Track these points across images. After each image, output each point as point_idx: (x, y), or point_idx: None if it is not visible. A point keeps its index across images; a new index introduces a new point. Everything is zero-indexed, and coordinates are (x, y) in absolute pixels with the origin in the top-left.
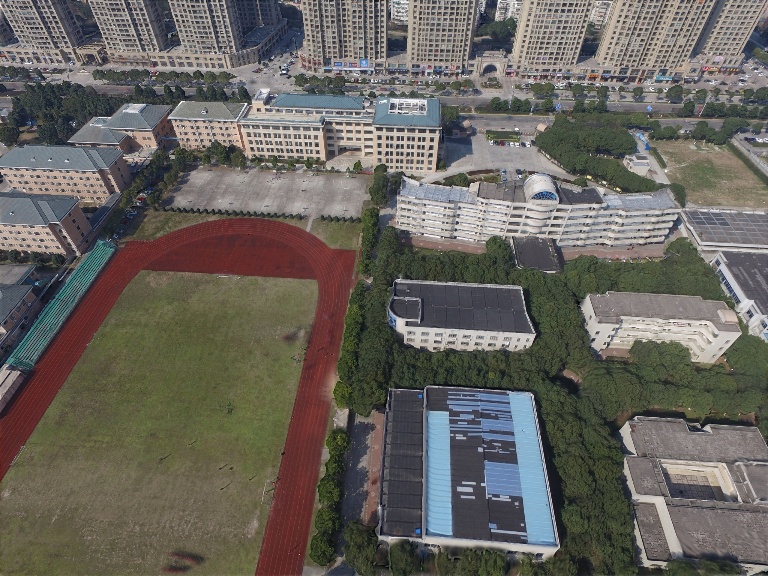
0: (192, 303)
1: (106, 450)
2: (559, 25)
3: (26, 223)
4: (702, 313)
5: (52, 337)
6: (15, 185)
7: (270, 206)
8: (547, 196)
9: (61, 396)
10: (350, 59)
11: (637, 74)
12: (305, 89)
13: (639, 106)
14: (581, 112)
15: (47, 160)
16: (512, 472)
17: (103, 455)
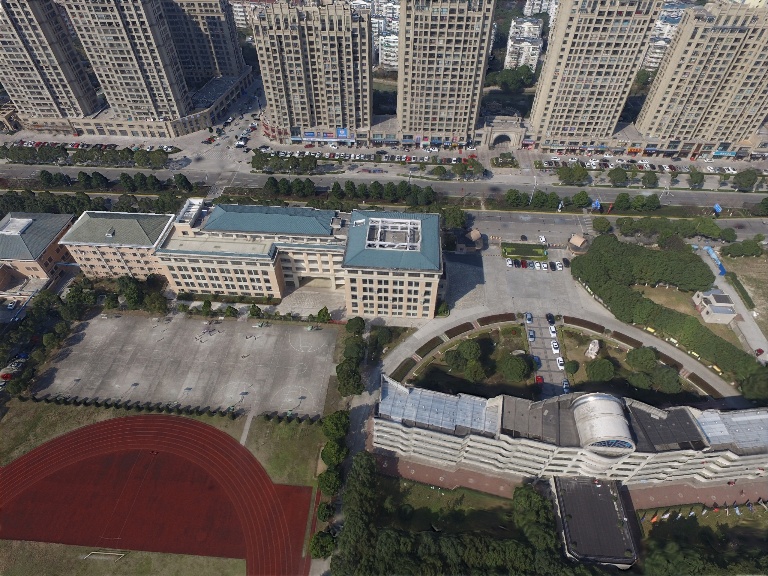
0: None
1: None
2: (593, 90)
3: None
4: None
5: None
6: None
7: (193, 389)
8: (616, 444)
9: None
10: (324, 128)
11: (690, 148)
12: (266, 170)
13: (698, 197)
14: (625, 209)
15: None
16: None
17: None
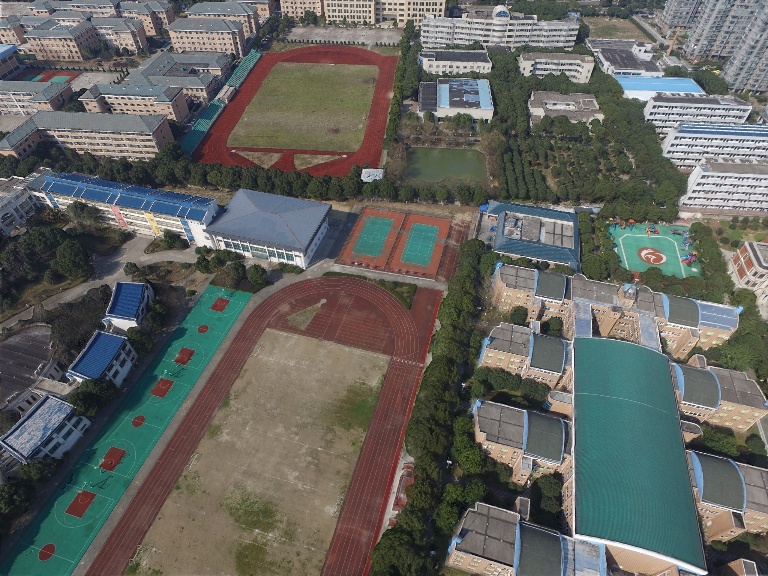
0: (311, 72)
1: (286, 109)
2: None
3: (220, 30)
4: (577, 59)
5: (243, 81)
6: None
7: None
8: (504, 14)
9: (256, 97)
10: None
11: None
12: None
13: (579, 2)
14: None
15: (217, 9)
16: (476, 96)
17: (285, 111)
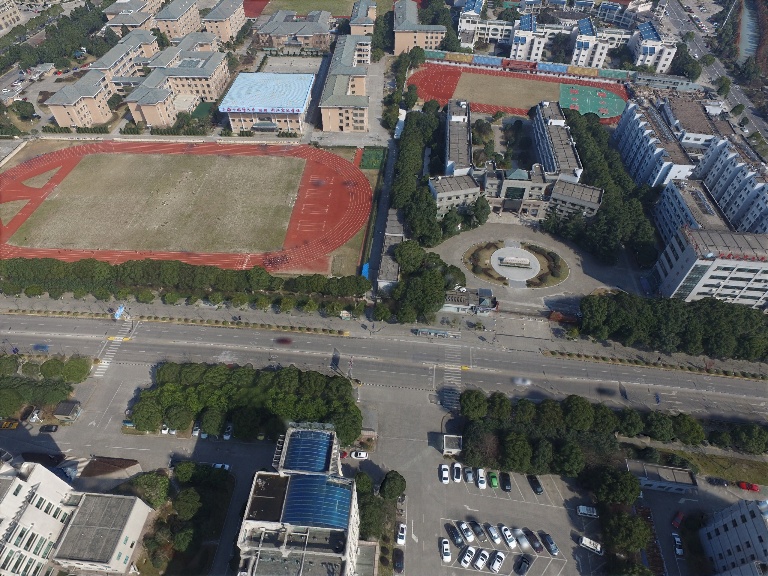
0: None
1: None
2: None
3: None
4: None
5: None
6: (181, 33)
7: None
8: None
9: None
10: None
11: None
12: None
13: None
14: None
15: (183, 6)
16: None
17: (345, 7)
